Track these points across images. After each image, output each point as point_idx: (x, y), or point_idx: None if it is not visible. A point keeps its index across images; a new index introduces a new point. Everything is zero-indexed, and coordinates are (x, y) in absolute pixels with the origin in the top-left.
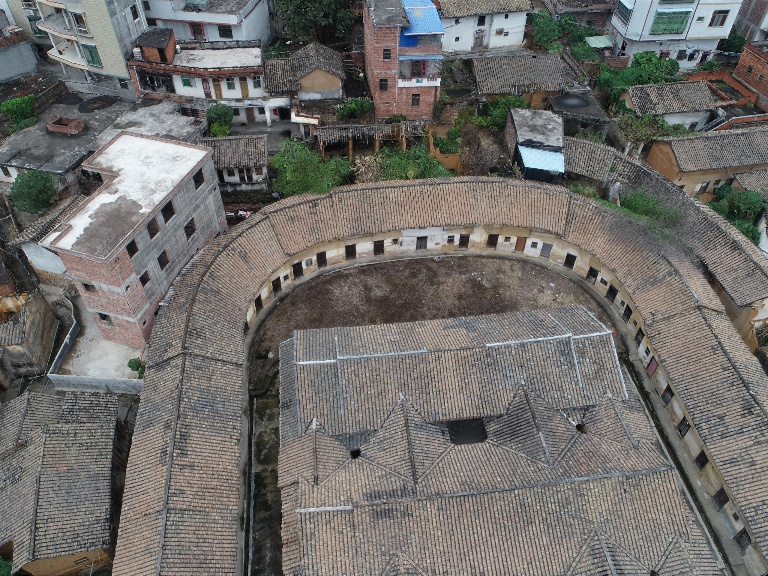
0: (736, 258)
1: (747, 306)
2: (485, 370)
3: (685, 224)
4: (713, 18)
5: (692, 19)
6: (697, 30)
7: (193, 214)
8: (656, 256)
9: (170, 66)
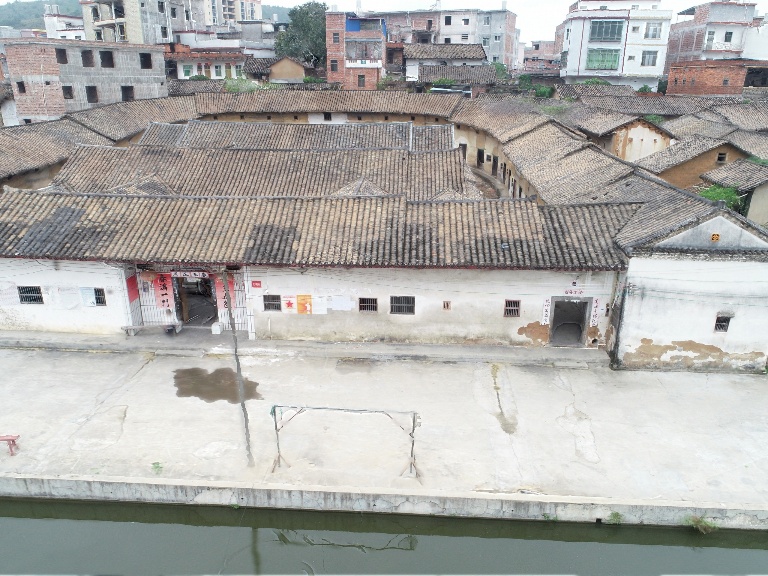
0: (608, 117)
1: (611, 136)
2: (320, 137)
3: (570, 114)
4: (644, 58)
5: (623, 58)
6: (631, 68)
7: (134, 83)
8: (527, 114)
9: (174, 54)
